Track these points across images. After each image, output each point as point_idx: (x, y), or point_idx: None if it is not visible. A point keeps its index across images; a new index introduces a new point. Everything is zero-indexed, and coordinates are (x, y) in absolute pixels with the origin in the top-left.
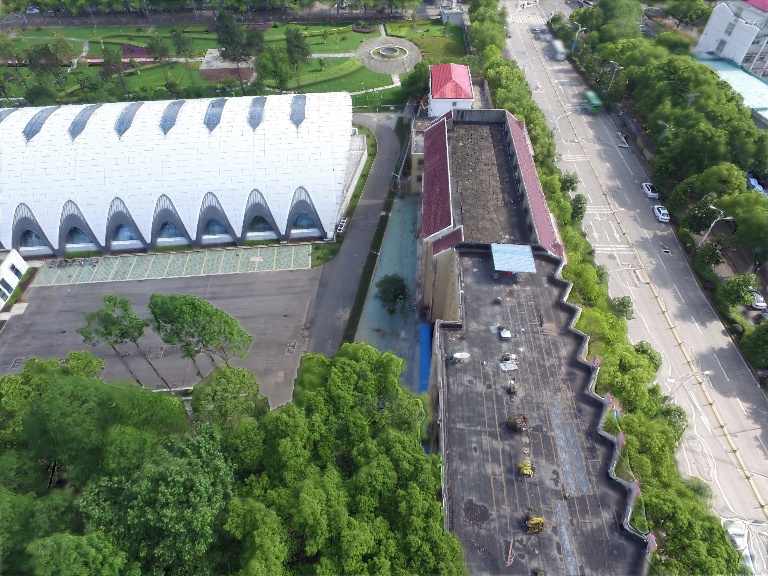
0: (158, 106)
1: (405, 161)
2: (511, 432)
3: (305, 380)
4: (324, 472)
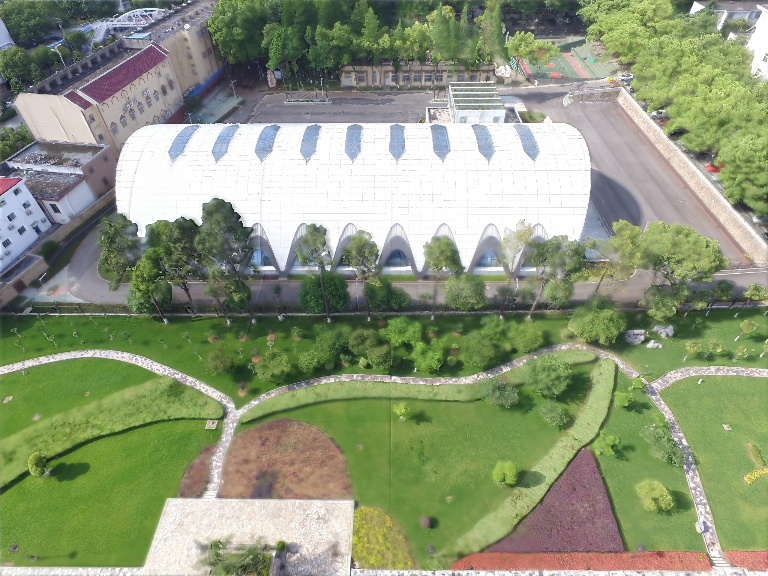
0: (327, 142)
1: (106, 194)
2: (187, 21)
3: (240, 16)
4: (240, 1)
